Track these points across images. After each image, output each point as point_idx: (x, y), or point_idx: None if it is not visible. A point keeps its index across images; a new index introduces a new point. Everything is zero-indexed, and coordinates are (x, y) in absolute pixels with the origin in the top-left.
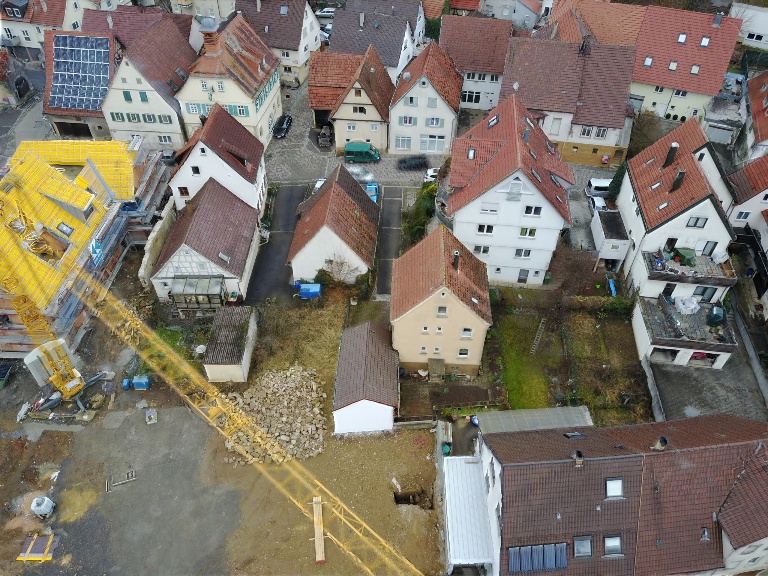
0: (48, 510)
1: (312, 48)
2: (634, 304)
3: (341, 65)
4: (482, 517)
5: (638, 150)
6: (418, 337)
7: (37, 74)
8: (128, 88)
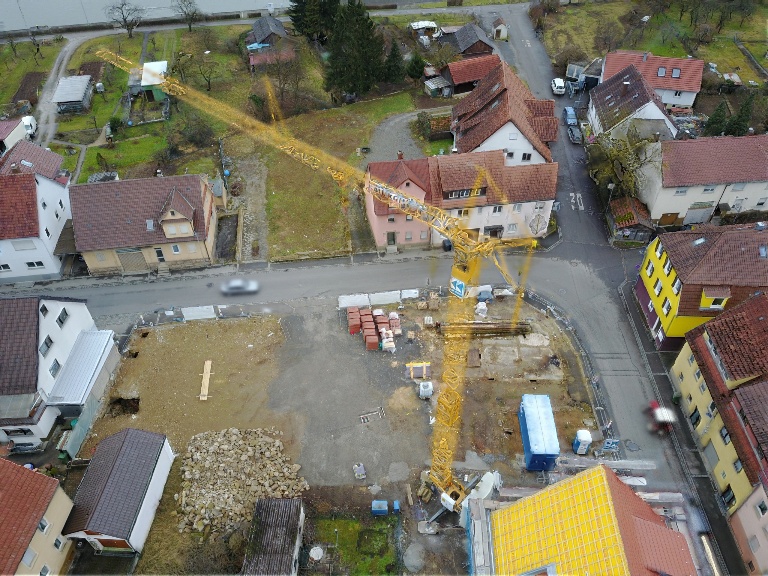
0: None
1: None
2: None
3: None
4: (74, 357)
5: None
6: None
7: None
8: None
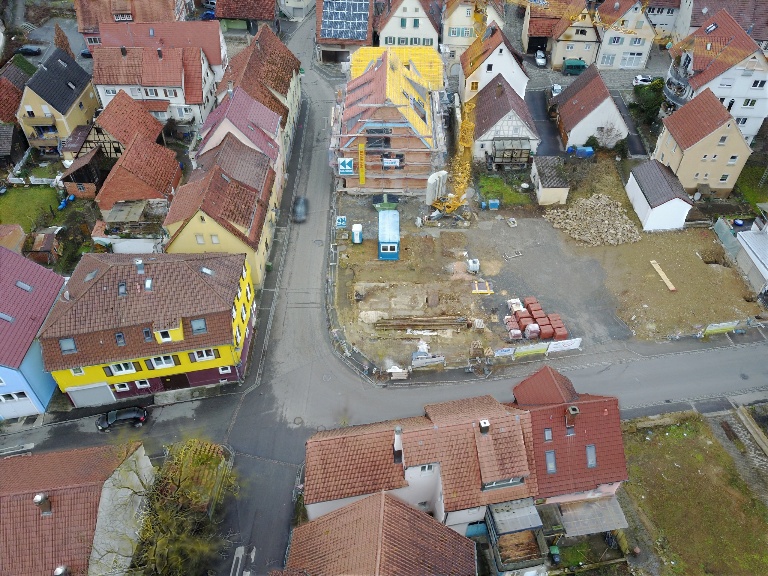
0: None
1: None
2: None
3: (557, 1)
4: None
5: None
6: (697, 164)
7: None
8: (406, 16)
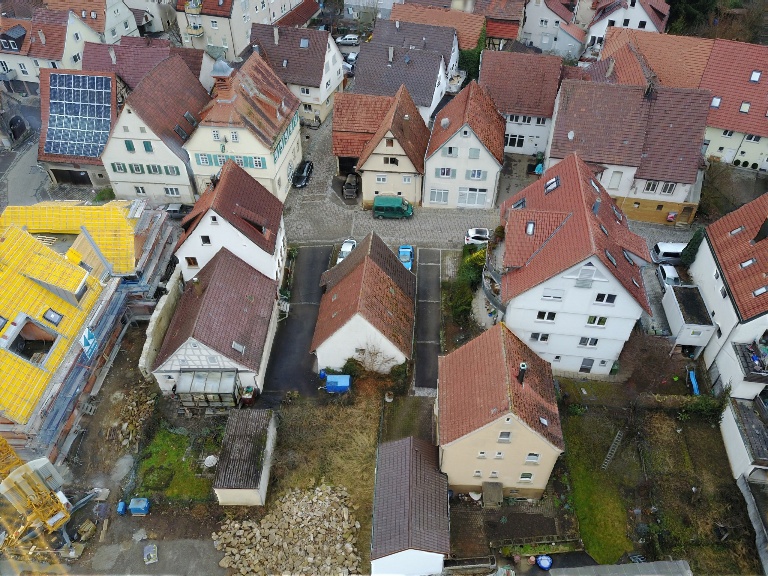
0: None
1: (334, 83)
2: (723, 406)
3: (369, 108)
4: None
5: (709, 206)
6: (472, 461)
7: (35, 110)
8: (131, 137)
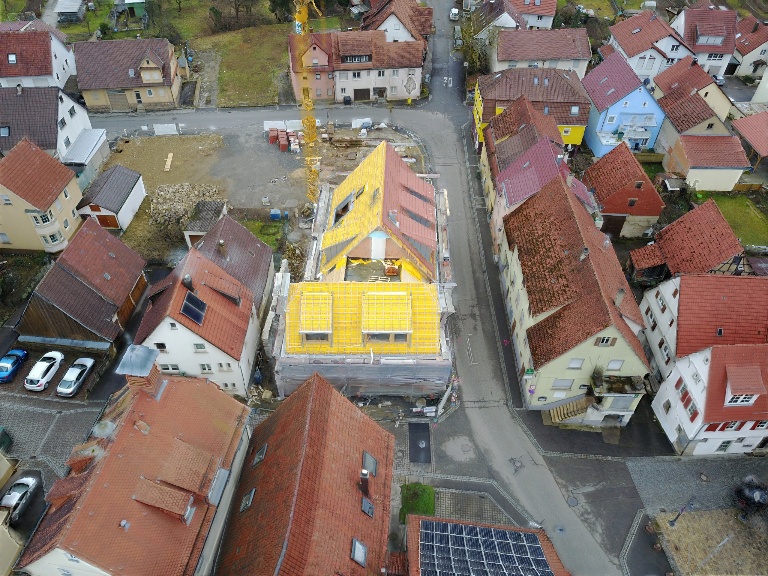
0: None
1: None
2: None
3: None
4: (79, 141)
5: None
6: None
7: None
8: None
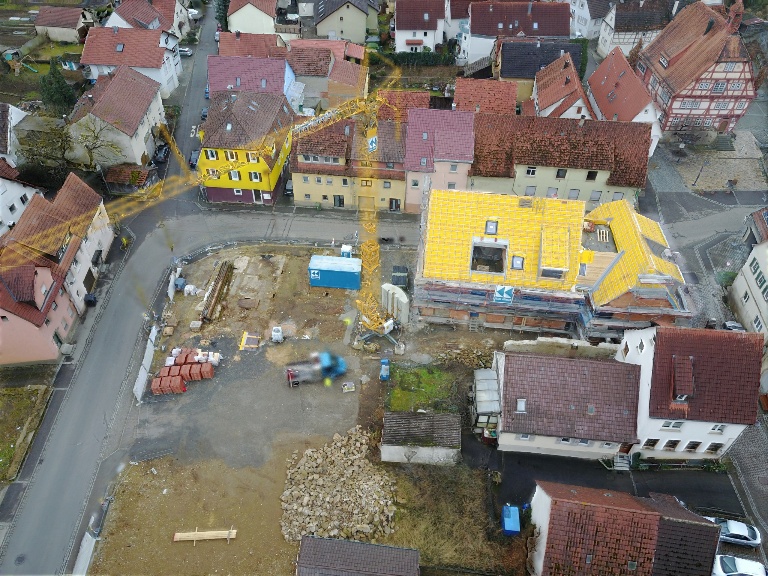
0: (274, 338)
1: None
2: None
3: None
4: None
5: None
6: None
7: None
8: None
